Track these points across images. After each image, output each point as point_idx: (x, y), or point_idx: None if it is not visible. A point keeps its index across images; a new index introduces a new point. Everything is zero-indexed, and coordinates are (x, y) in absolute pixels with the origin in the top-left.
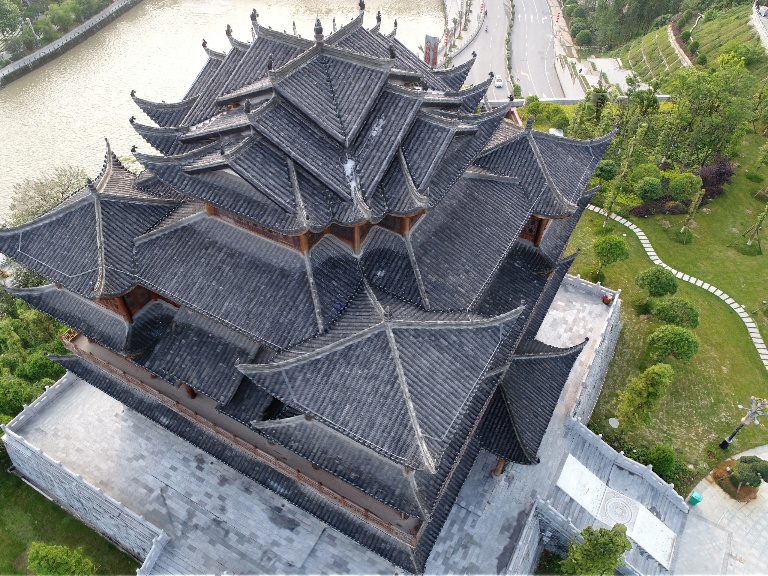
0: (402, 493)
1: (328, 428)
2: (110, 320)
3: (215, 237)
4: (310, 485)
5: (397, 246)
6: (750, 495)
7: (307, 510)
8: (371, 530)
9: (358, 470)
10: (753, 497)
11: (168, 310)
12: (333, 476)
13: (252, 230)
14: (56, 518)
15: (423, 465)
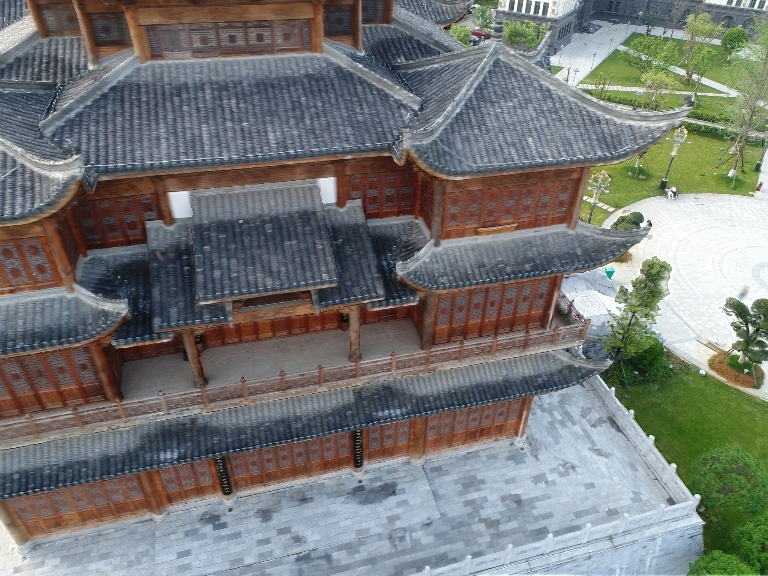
0: (585, 248)
1: (464, 240)
2: (31, 307)
3: (178, 80)
4: (444, 361)
5: (392, 33)
6: (627, 255)
7: (443, 408)
8: (518, 376)
9: (528, 259)
10: (630, 255)
11: (117, 258)
12: (451, 343)
13: (226, 54)
14: None
15: (657, 130)
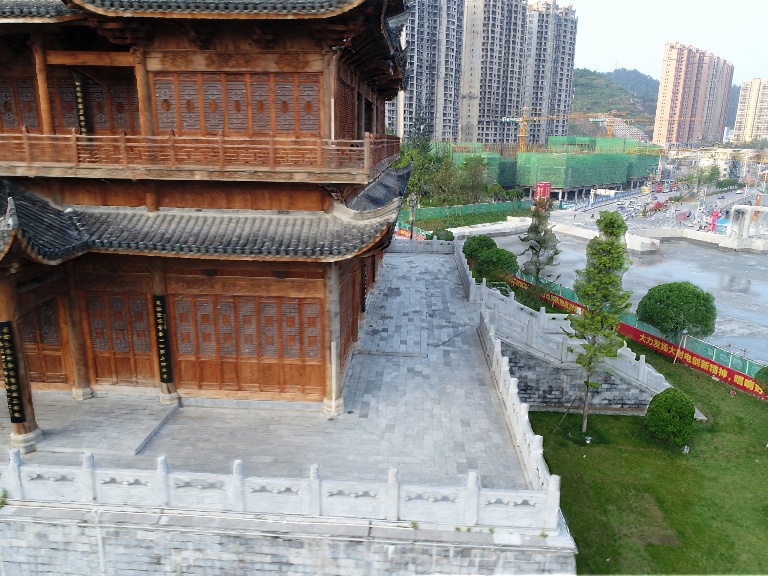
0: None
1: None
2: None
3: None
4: None
5: None
6: None
7: None
8: None
9: None
10: None
11: None
12: None
13: None
14: (572, 533)
15: None
